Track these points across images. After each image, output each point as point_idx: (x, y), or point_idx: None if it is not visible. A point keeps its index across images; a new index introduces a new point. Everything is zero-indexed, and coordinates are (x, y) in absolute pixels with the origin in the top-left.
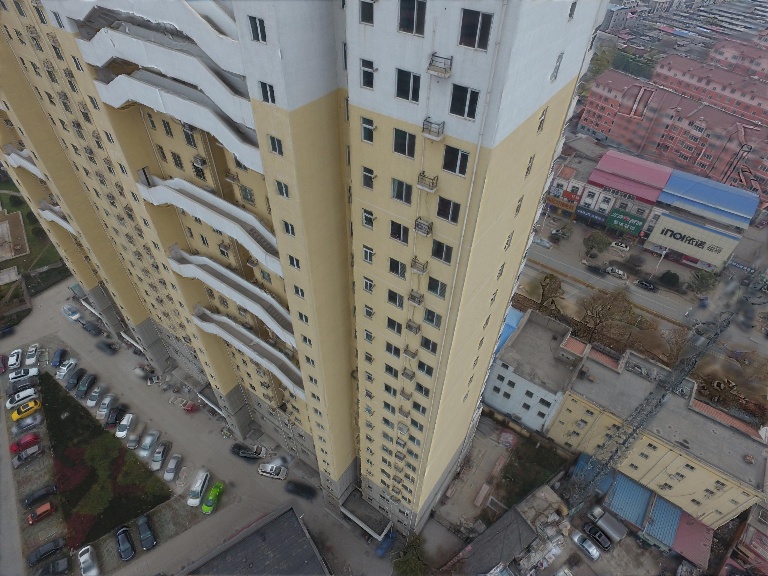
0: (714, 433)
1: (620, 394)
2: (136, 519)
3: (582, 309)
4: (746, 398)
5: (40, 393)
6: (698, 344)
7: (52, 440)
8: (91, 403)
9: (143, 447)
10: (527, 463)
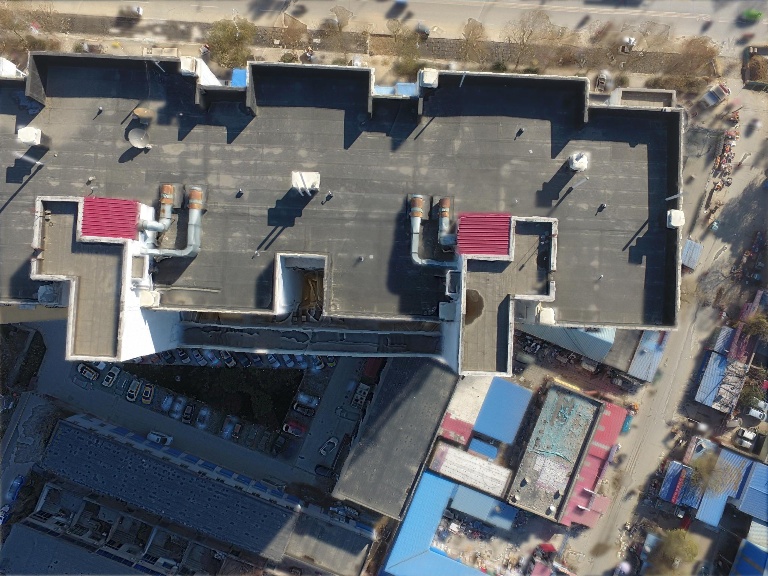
0: None
1: None
2: (296, 396)
3: (497, 24)
4: (643, 49)
5: (140, 378)
6: (601, 7)
7: (191, 396)
8: (186, 361)
9: (256, 361)
10: None
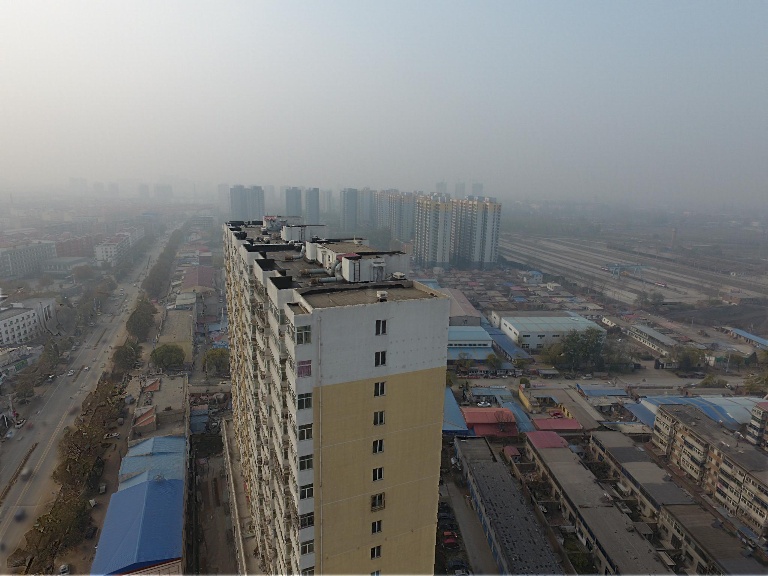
0: (166, 385)
1: (170, 402)
2: None
3: (42, 493)
4: None
5: None
6: (44, 449)
7: None
8: None
9: None
10: (209, 451)
